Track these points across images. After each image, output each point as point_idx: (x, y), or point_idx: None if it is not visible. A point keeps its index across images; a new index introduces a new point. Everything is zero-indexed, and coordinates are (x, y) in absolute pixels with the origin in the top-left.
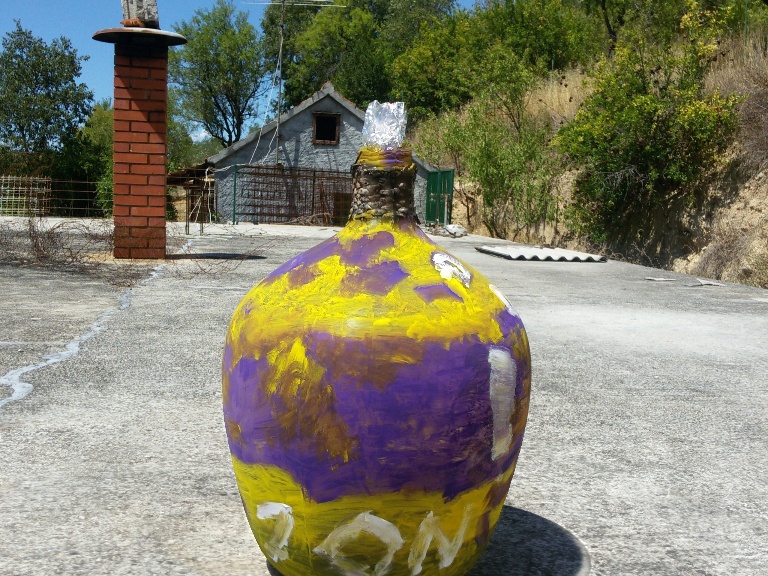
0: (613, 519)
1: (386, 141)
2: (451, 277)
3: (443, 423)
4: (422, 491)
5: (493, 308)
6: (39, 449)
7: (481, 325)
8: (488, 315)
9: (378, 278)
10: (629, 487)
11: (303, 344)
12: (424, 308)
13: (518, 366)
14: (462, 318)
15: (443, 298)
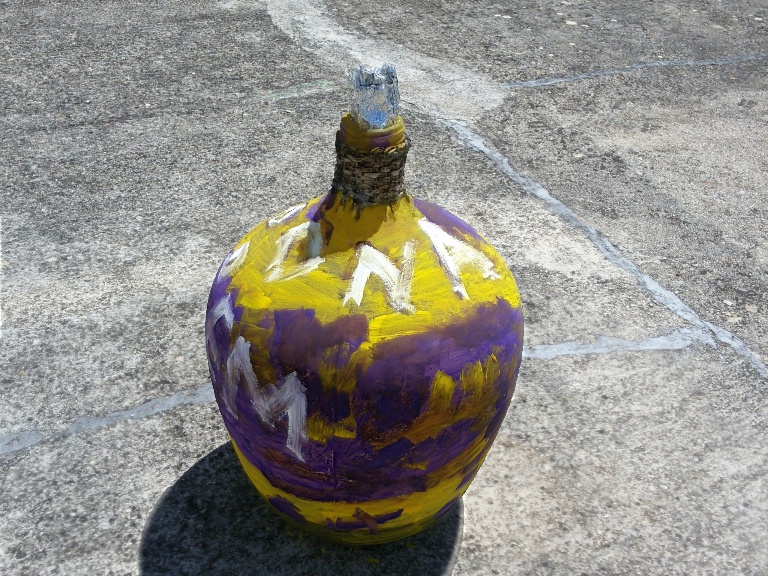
0: None
1: None
2: None
3: None
4: None
5: None
6: None
7: None
8: None
9: None
10: None
11: None
12: None
13: None
14: None
15: None
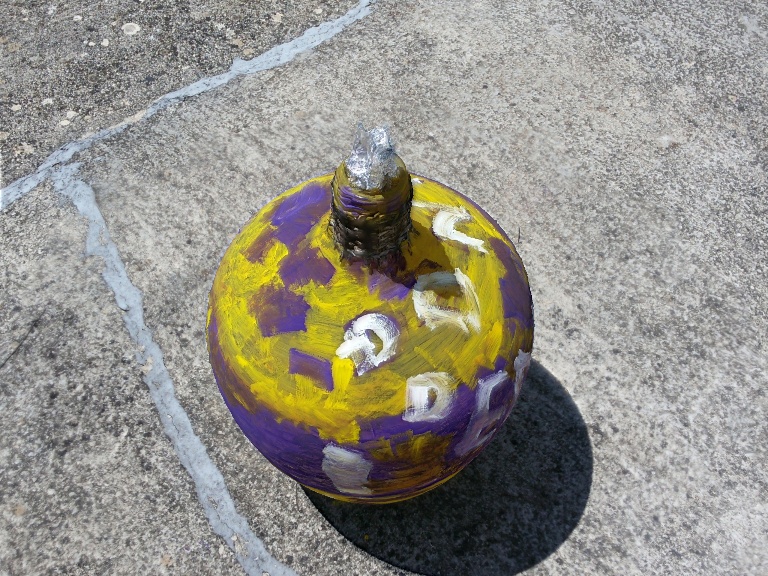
0: (649, 550)
1: (359, 171)
2: (348, 355)
3: (274, 455)
4: (275, 466)
5: (370, 410)
6: (377, 67)
7: (329, 422)
8: (353, 415)
9: (281, 310)
10: (766, 529)
11: (210, 317)
12: (283, 374)
13: (379, 464)
14: (311, 406)
15: (310, 376)
